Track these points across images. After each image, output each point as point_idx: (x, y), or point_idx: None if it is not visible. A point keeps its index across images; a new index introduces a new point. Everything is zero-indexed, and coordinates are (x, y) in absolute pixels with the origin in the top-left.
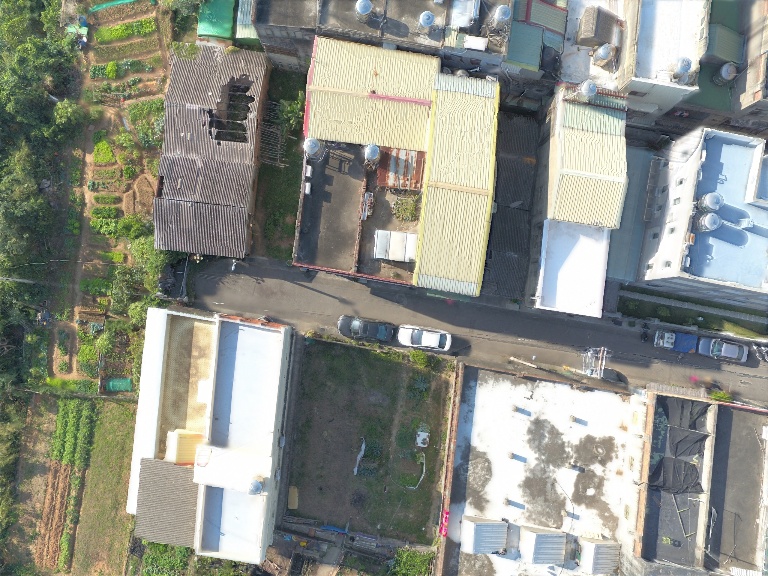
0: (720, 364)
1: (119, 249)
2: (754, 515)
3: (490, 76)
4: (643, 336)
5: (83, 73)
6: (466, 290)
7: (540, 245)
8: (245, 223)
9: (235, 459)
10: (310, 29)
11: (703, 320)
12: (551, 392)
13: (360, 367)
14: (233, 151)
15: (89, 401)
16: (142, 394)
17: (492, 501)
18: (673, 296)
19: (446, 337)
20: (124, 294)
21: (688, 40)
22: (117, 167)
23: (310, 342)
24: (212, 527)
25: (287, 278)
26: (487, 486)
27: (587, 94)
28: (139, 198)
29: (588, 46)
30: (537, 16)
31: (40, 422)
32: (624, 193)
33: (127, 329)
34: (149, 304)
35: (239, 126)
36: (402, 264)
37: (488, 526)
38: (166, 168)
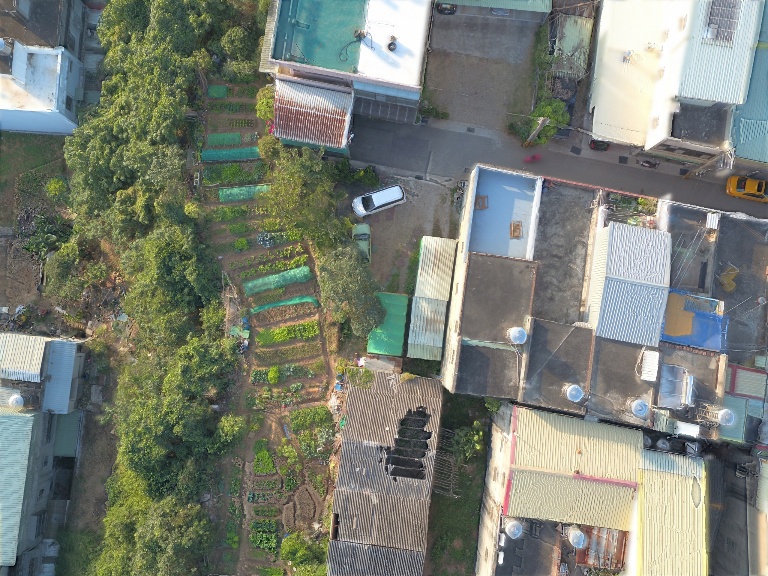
0: None
1: (278, 564)
2: None
3: (689, 443)
4: None
5: (243, 377)
6: None
7: None
8: (422, 566)
9: None
10: None
11: None
12: None
13: None
14: (409, 487)
15: None
16: None
17: None
18: None
19: None
20: None
21: None
22: (277, 478)
23: None
24: None
25: None
26: None
27: None
28: (299, 511)
29: None
30: (740, 386)
31: None
32: None
33: None
34: None
35: (406, 443)
36: None
37: None
38: (340, 504)
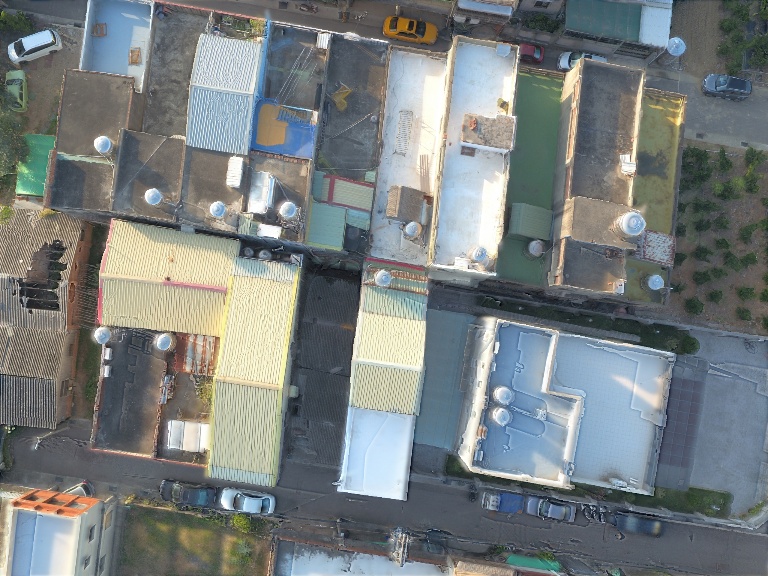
0: (550, 522)
1: None
2: None
3: (294, 255)
4: (471, 497)
5: None
6: (262, 481)
7: None
8: (55, 395)
9: None
10: (107, 211)
11: None
12: (369, 564)
13: (183, 532)
14: (45, 319)
15: None
16: None
17: None
18: None
19: (269, 502)
20: None
21: (488, 224)
22: None
23: (132, 506)
24: None
25: None
26: None
27: (381, 284)
28: None
29: (398, 220)
30: (340, 196)
31: None
32: (421, 381)
33: None
34: None
35: None
36: None
37: None
38: None
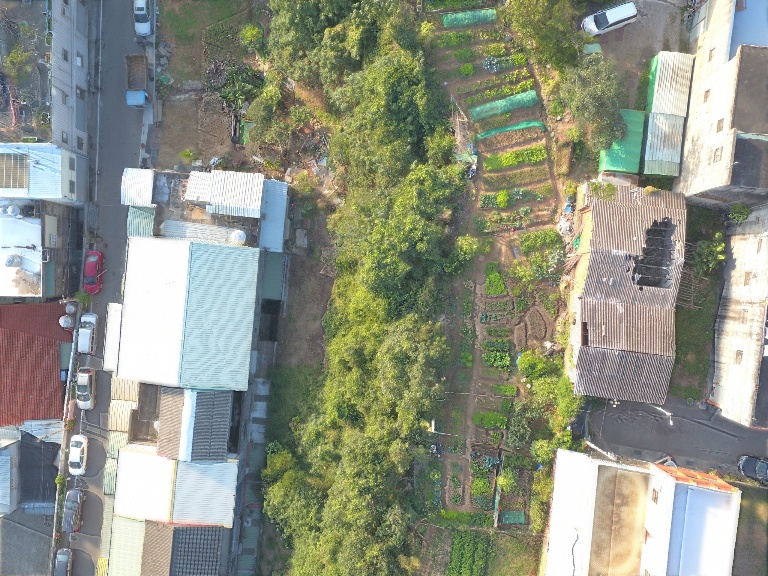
0: None
1: (511, 382)
2: None
3: None
4: None
5: (471, 202)
6: None
7: None
8: (670, 371)
9: None
10: None
11: None
12: None
13: (760, 506)
14: (654, 296)
15: (484, 534)
16: (554, 535)
17: None
18: None
19: None
20: (528, 432)
21: None
22: (509, 299)
23: None
24: None
25: (686, 416)
26: None
27: None
28: (531, 331)
29: None
30: None
31: (435, 553)
32: None
33: (526, 465)
34: (557, 444)
35: None
36: None
37: None
38: (588, 314)
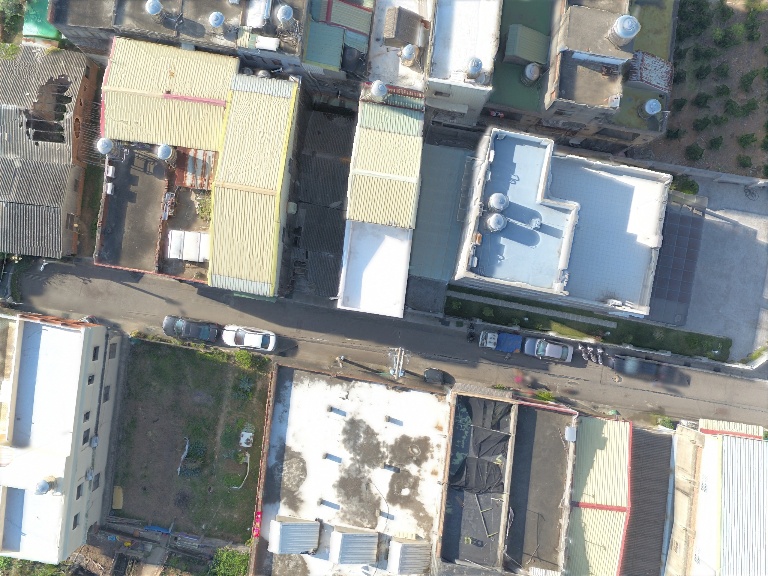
0: (547, 364)
1: None
2: (557, 515)
3: (293, 77)
4: (468, 336)
5: None
6: (260, 290)
7: None
8: (60, 223)
9: (34, 459)
10: (109, 29)
11: (530, 320)
12: (366, 392)
13: (186, 367)
14: (51, 151)
15: None
16: None
17: (307, 501)
18: (500, 296)
19: (269, 337)
20: None
21: (484, 41)
22: None
23: (136, 342)
24: (13, 527)
25: (114, 278)
26: (302, 486)
27: (377, 94)
28: None
29: (396, 47)
30: (338, 17)
31: None
32: (417, 193)
33: None
34: None
35: None
36: (207, 264)
37: (296, 526)
38: None
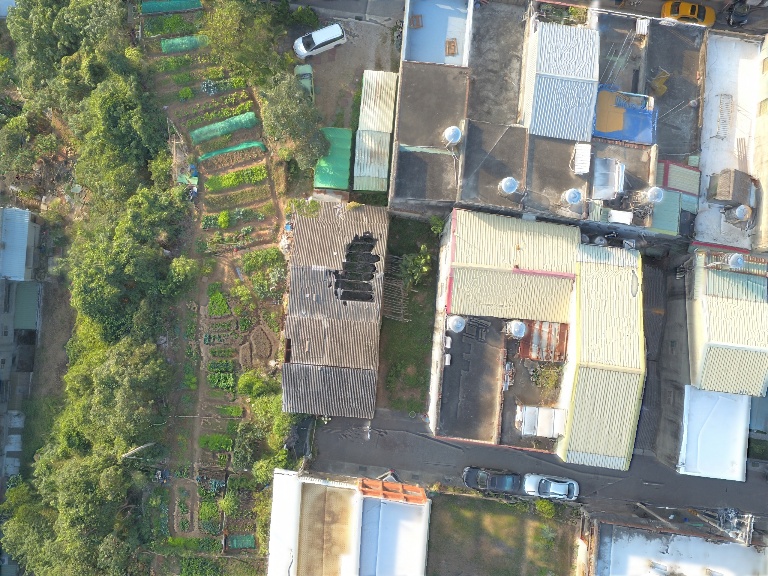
0: None
1: (237, 403)
2: None
3: (627, 241)
4: None
5: (194, 223)
6: (616, 465)
7: (682, 410)
8: (375, 385)
9: None
10: (448, 201)
11: None
12: (686, 546)
13: (486, 518)
14: (359, 310)
15: (213, 560)
16: (272, 558)
17: None
18: None
19: (574, 487)
20: (248, 453)
21: None
22: (232, 319)
23: (435, 494)
24: None
25: (410, 429)
26: None
27: (734, 267)
28: (256, 350)
29: (720, 204)
30: (673, 181)
31: None
32: None
33: (250, 487)
34: (275, 464)
35: (357, 277)
36: None
37: None
38: (292, 330)
